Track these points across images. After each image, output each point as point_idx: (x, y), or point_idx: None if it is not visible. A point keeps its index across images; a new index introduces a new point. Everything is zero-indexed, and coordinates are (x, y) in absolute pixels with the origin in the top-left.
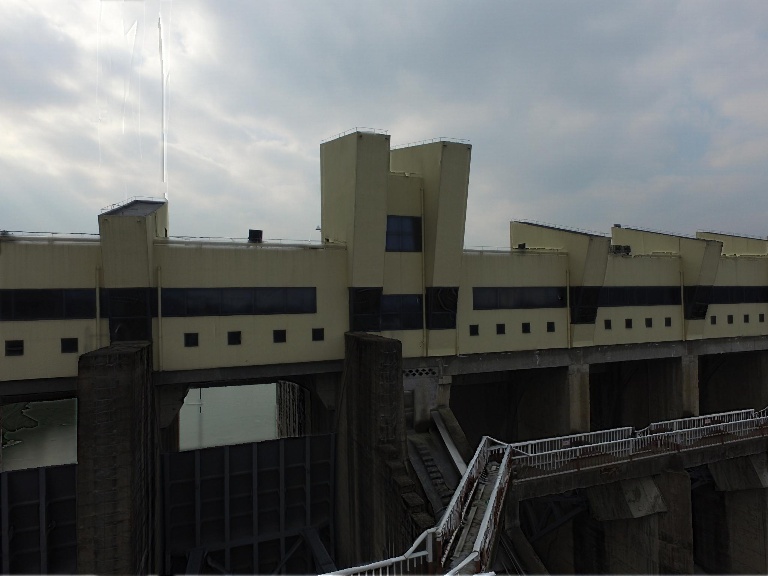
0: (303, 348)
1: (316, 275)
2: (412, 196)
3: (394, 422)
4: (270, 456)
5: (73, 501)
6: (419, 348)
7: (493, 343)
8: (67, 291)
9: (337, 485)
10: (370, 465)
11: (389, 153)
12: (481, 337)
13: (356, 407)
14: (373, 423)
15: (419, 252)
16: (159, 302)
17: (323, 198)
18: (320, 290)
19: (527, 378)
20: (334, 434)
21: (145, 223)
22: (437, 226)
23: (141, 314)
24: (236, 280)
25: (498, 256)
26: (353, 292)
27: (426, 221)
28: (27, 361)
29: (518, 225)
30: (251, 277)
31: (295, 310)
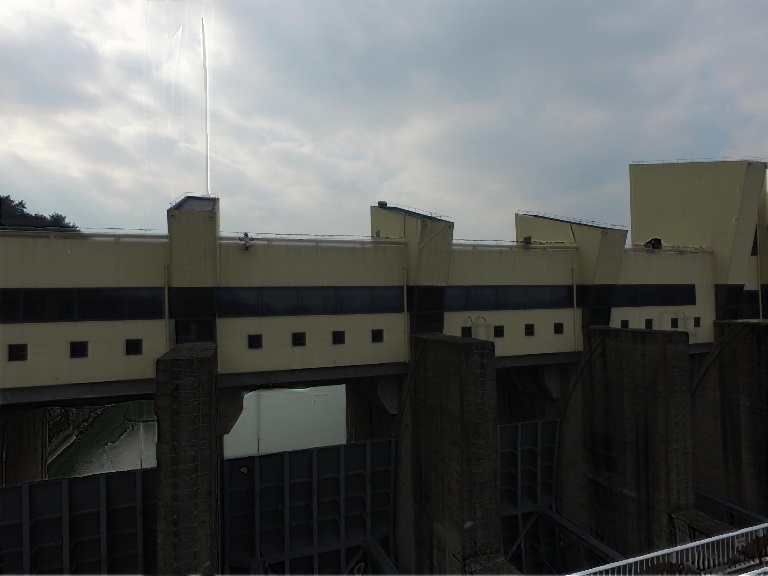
0: None
1: (694, 274)
2: None
3: None
4: None
5: (530, 451)
6: None
7: None
8: (556, 287)
9: None
10: None
11: (764, 177)
12: None
13: (749, 379)
14: None
15: (755, 255)
16: None
17: (636, 210)
18: (697, 286)
19: None
20: None
21: None
22: None
23: (606, 305)
24: (648, 278)
25: None
26: (726, 288)
27: (762, 230)
28: (536, 340)
29: None
30: (657, 276)
31: (682, 302)
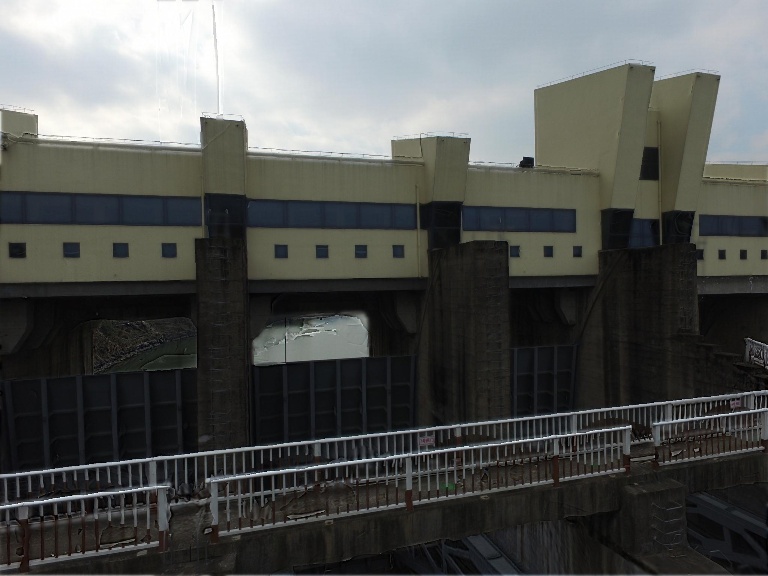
0: (566, 263)
1: (575, 198)
2: (650, 128)
3: (690, 314)
4: (524, 362)
5: (381, 389)
6: None
7: (715, 267)
8: (395, 205)
9: (578, 391)
10: (659, 355)
11: (652, 83)
12: (705, 261)
13: (627, 311)
14: (668, 316)
15: (656, 180)
16: (461, 217)
17: (539, 139)
18: (579, 212)
19: (718, 311)
20: (576, 345)
21: (469, 144)
22: (683, 153)
23: (454, 225)
24: (515, 201)
25: (720, 186)
26: (611, 213)
27: (663, 151)
28: (370, 263)
29: (708, 165)
30: (526, 198)
31: (559, 229)
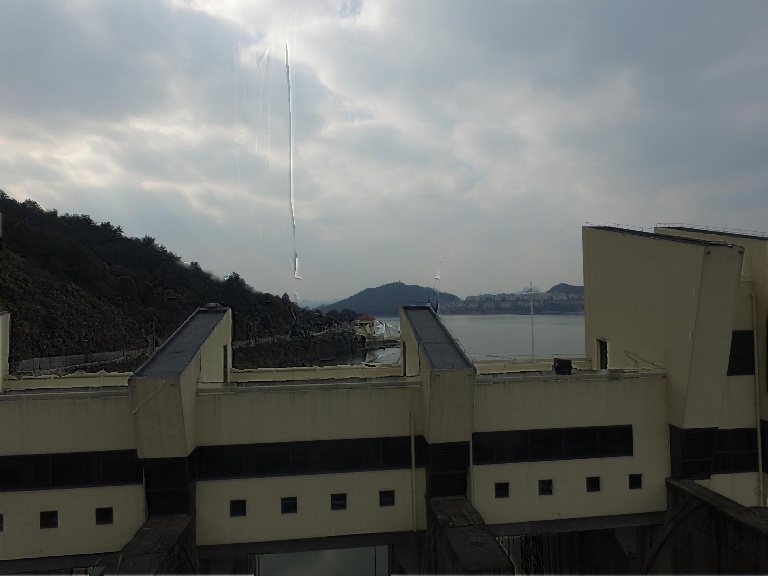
0: (619, 498)
1: (631, 410)
2: (740, 305)
3: None
4: None
5: None
6: (753, 496)
7: None
8: (383, 440)
9: None
10: None
11: (741, 269)
12: None
13: None
14: None
15: (750, 375)
16: (470, 449)
17: (590, 290)
18: (636, 428)
19: None
20: None
21: (474, 376)
22: None
23: (459, 468)
24: (546, 420)
25: None
26: (682, 434)
27: (761, 337)
28: (350, 515)
29: None
30: (561, 416)
31: (608, 452)
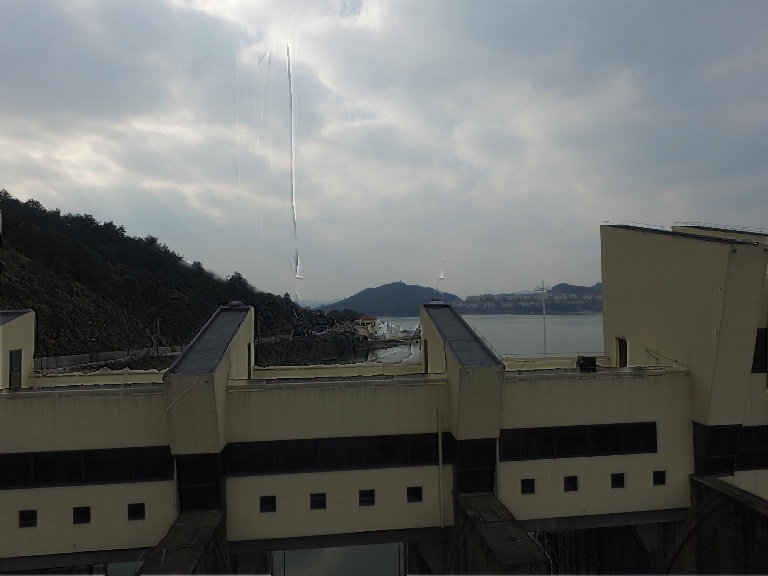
0: (643, 494)
1: (655, 407)
2: (762, 303)
3: None
4: None
5: None
6: None
7: None
8: (411, 436)
9: None
10: None
11: (766, 267)
12: None
13: None
14: None
15: None
16: (497, 446)
17: (608, 288)
18: (660, 425)
19: None
20: None
21: (503, 373)
22: None
23: (486, 464)
24: (571, 417)
25: None
26: (707, 431)
27: None
28: (378, 511)
29: None
30: (586, 413)
31: (632, 449)
